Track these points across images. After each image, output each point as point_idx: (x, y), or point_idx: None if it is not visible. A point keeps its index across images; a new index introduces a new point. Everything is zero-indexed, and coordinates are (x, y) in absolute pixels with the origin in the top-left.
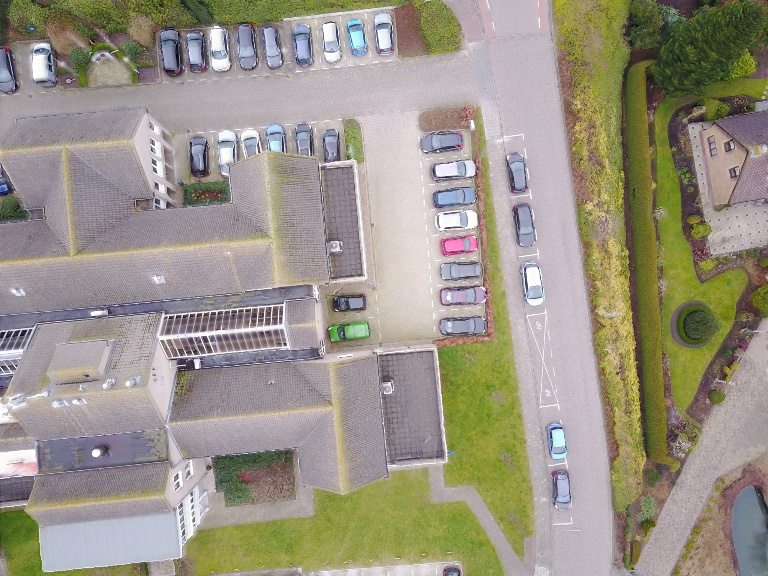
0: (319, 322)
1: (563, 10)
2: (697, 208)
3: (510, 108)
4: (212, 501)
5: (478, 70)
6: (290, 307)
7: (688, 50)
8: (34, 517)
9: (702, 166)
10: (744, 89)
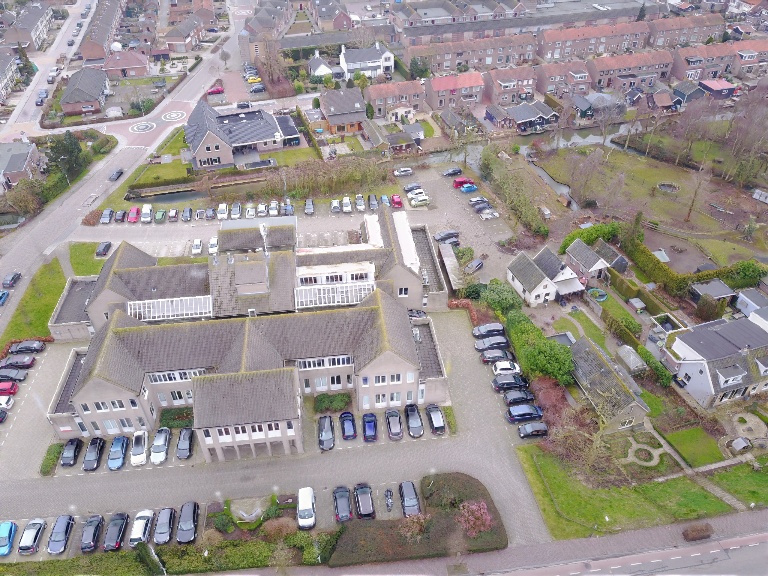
0: None
1: None
2: None
3: None
4: None
5: None
6: None
7: None
8: None
9: None
10: None
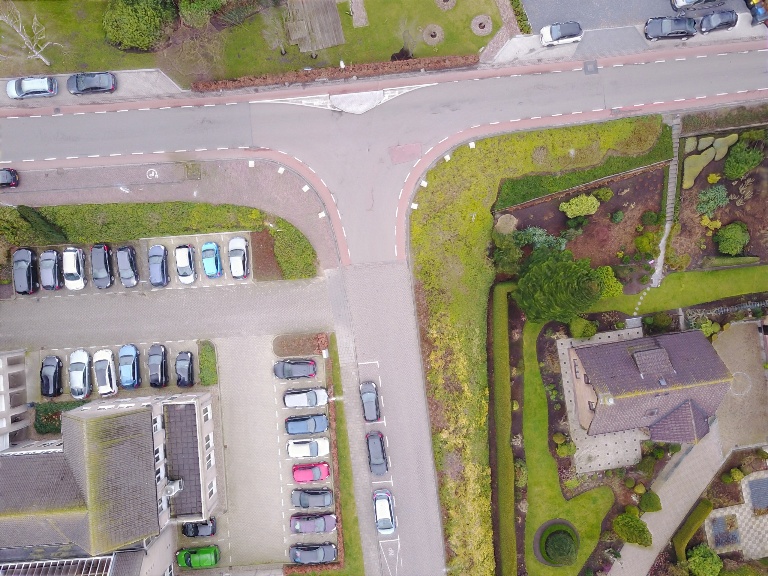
0: (157, 562)
1: (419, 240)
2: (563, 426)
3: (365, 335)
4: None
5: (333, 297)
6: (117, 561)
7: (537, 297)
8: None
9: (570, 383)
10: (616, 305)
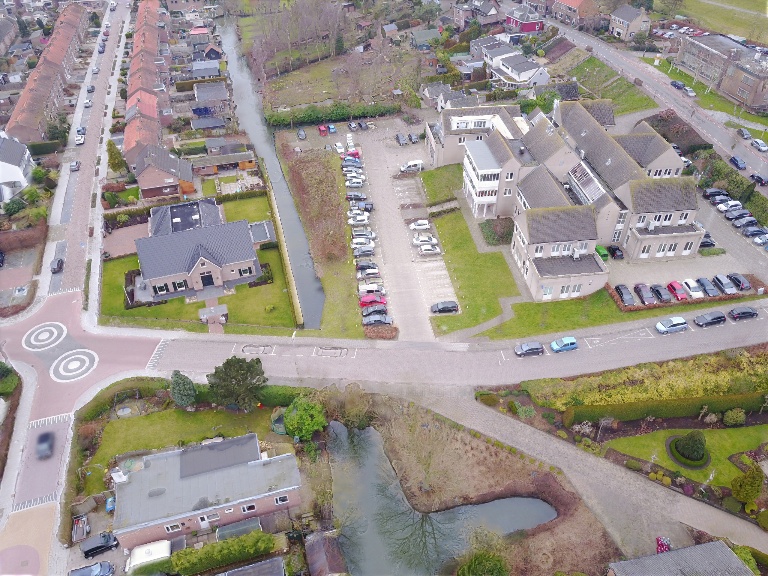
0: (605, 224)
1: None
2: None
3: None
4: (480, 219)
5: None
6: None
7: None
8: (491, 134)
9: None
10: None
